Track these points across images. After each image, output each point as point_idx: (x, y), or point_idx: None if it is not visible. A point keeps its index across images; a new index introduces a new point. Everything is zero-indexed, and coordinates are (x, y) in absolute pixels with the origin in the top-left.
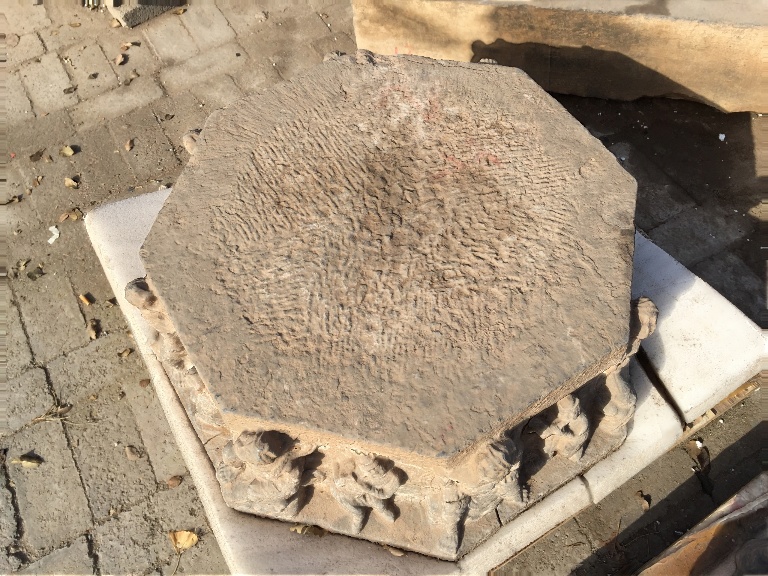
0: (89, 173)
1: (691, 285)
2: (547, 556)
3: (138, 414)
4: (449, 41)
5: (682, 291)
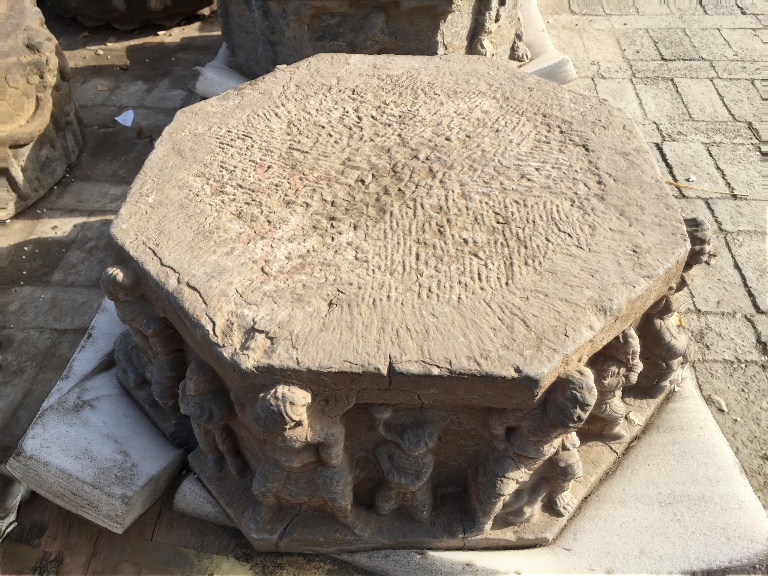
0: None
1: None
2: None
3: None
4: None
5: None
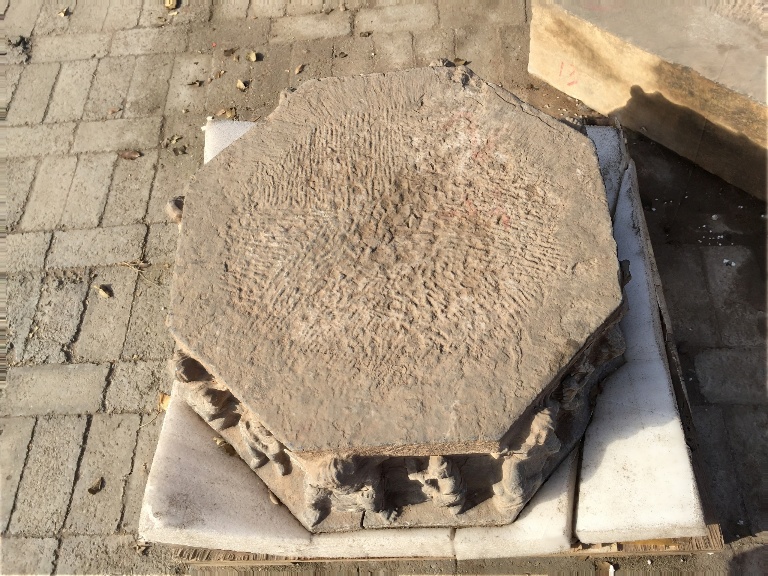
0: (258, 82)
1: (666, 422)
2: (414, 575)
3: None
4: (611, 75)
5: (654, 422)
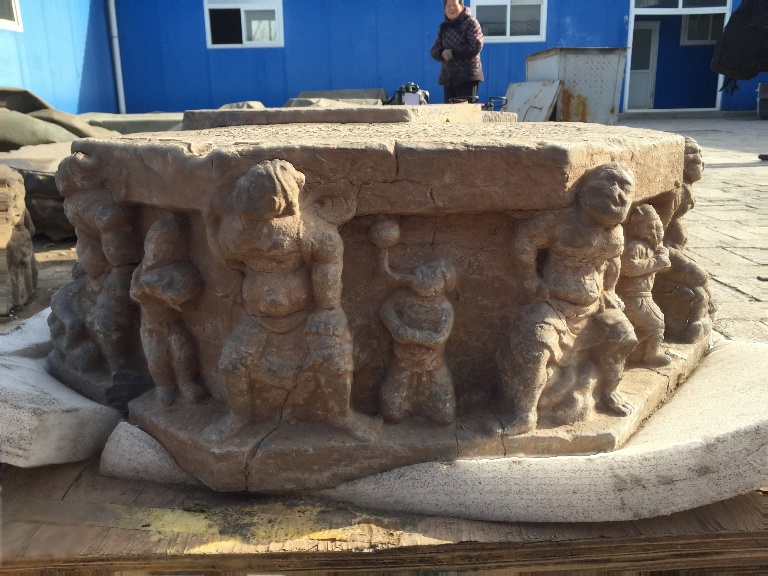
0: None
1: None
2: None
3: (766, 449)
4: None
5: None
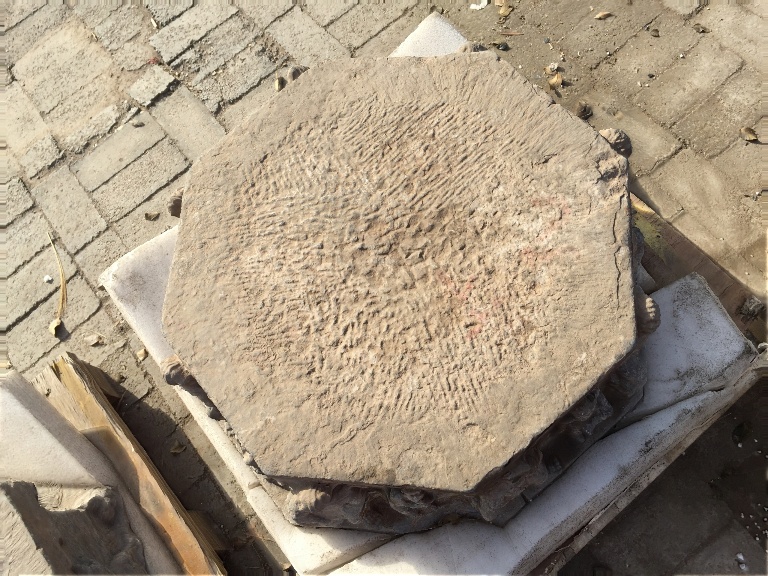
0: None
1: None
2: None
3: None
4: None
5: None
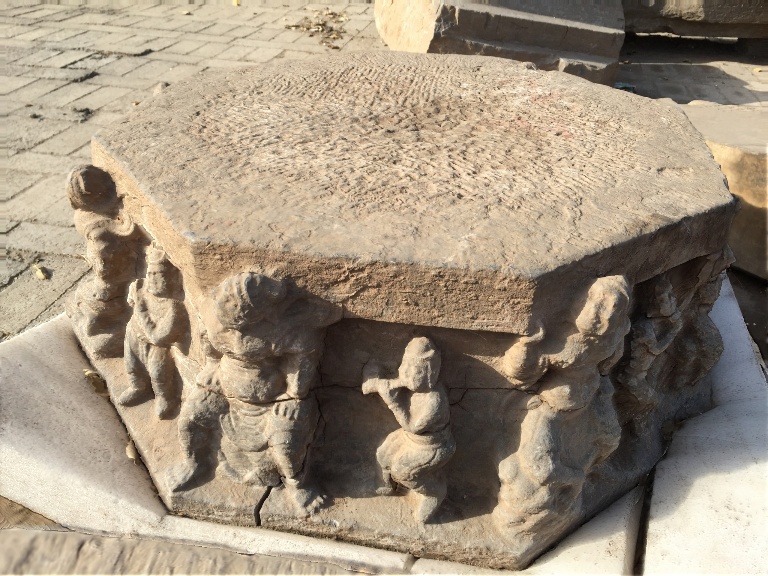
0: None
1: None
2: None
3: None
4: None
5: None
